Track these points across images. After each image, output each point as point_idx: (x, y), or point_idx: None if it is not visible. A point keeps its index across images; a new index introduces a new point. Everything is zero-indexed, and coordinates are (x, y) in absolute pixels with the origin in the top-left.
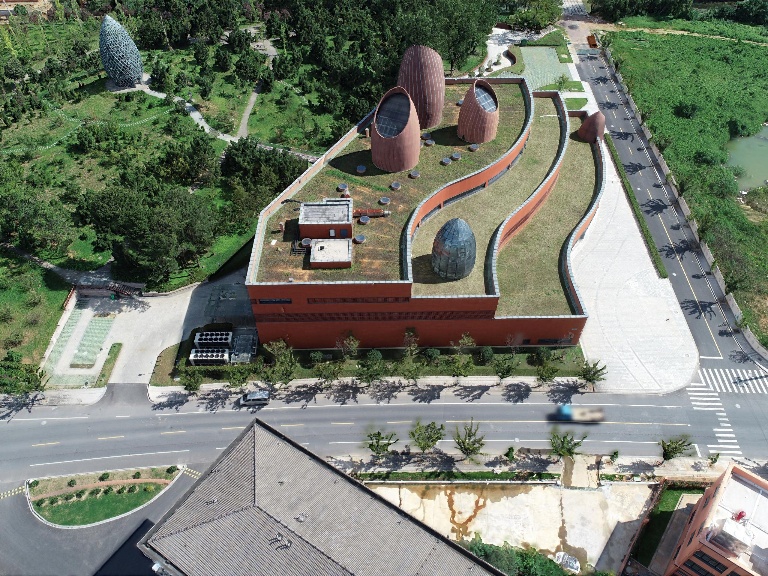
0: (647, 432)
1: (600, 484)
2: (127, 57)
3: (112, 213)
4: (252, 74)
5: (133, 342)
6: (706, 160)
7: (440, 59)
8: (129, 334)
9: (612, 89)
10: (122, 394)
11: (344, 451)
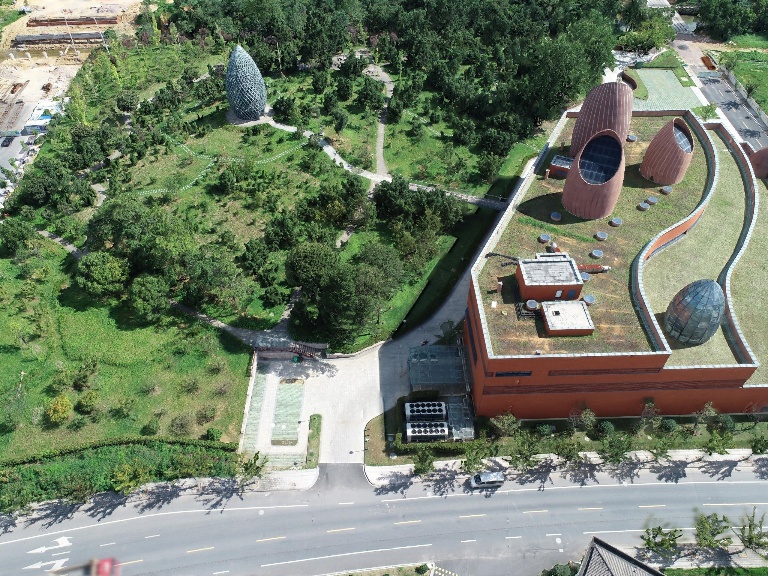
0: None
1: None
2: (255, 89)
3: (315, 274)
4: (376, 104)
5: (332, 413)
6: None
7: None
8: (325, 403)
9: (747, 115)
10: (338, 476)
11: None
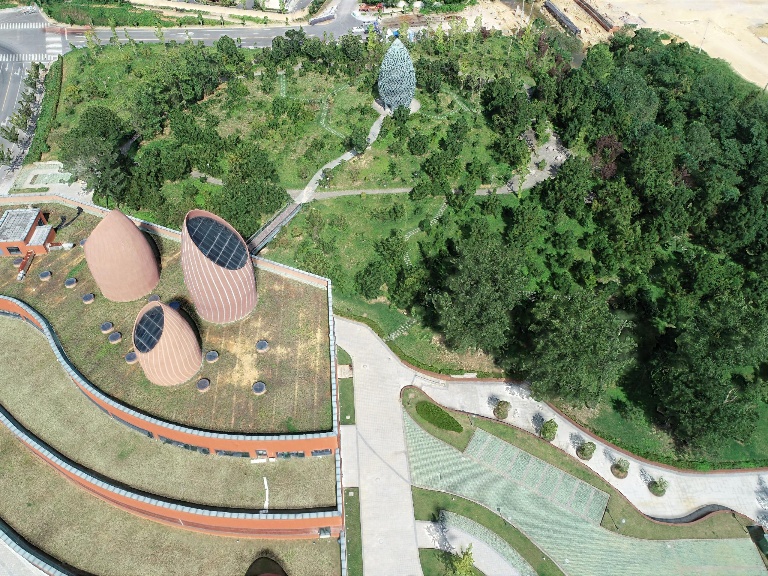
0: None
1: None
2: (386, 81)
3: None
4: (435, 175)
5: None
6: None
7: (195, 250)
8: None
9: None
10: None
11: None
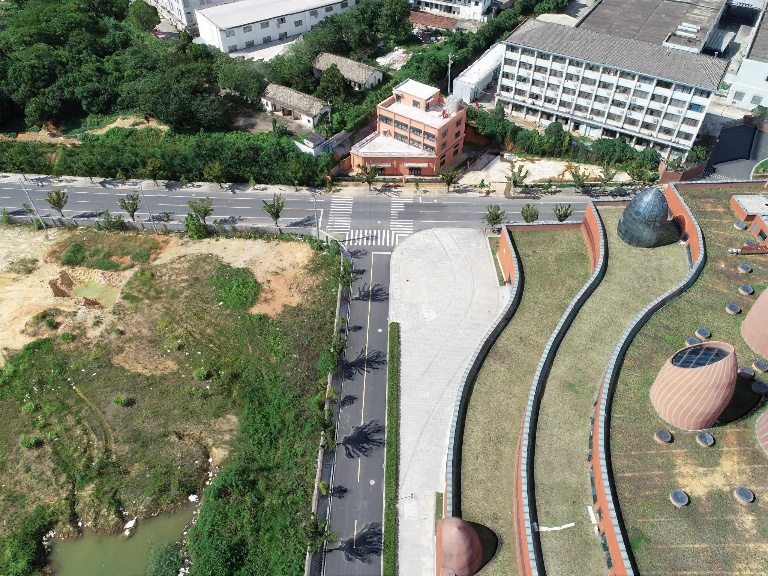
0: (452, 208)
1: None
2: None
3: None
4: None
5: None
6: None
7: None
8: None
9: None
10: None
11: None
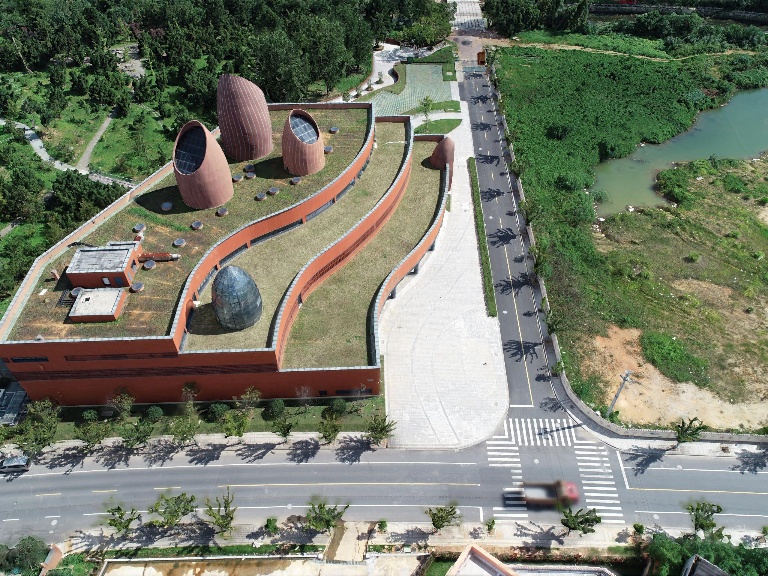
0: (432, 494)
1: (365, 557)
2: None
3: None
4: (108, 98)
5: None
6: (565, 185)
7: (255, 88)
8: None
9: (490, 109)
10: None
11: (97, 524)
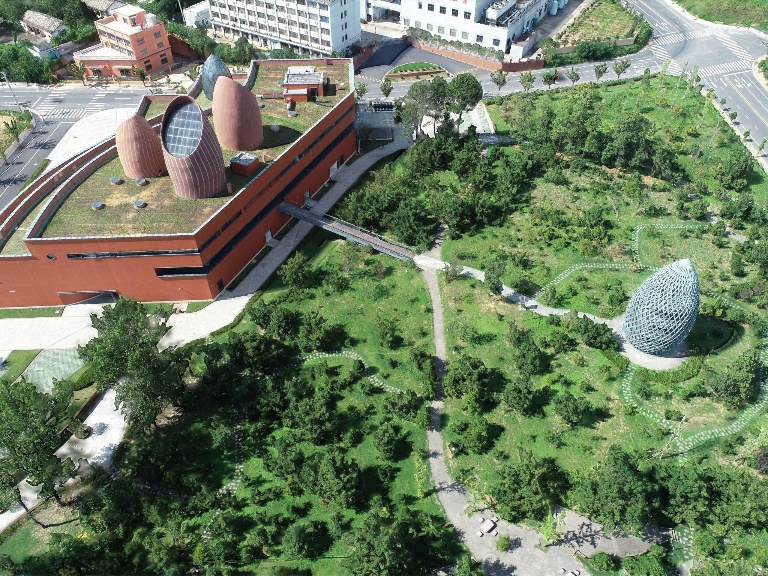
0: (141, 96)
1: None
2: None
3: None
4: None
5: None
6: None
7: (165, 115)
8: None
9: None
10: None
11: None
